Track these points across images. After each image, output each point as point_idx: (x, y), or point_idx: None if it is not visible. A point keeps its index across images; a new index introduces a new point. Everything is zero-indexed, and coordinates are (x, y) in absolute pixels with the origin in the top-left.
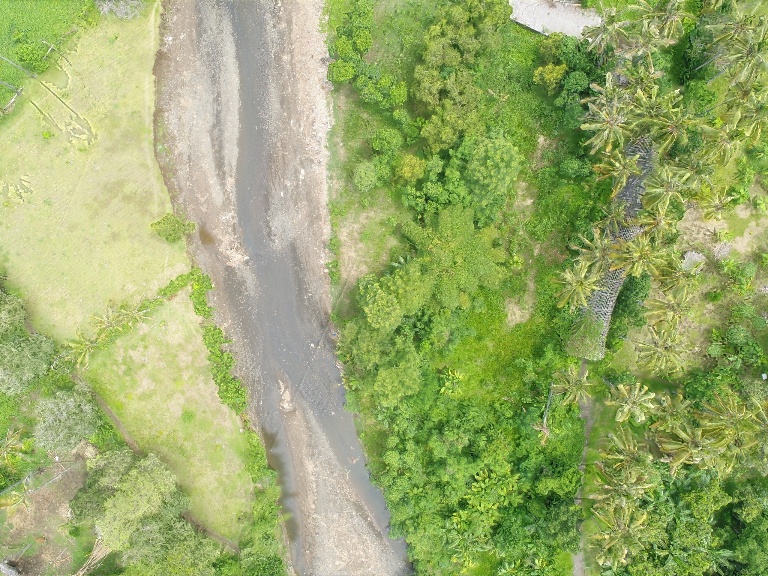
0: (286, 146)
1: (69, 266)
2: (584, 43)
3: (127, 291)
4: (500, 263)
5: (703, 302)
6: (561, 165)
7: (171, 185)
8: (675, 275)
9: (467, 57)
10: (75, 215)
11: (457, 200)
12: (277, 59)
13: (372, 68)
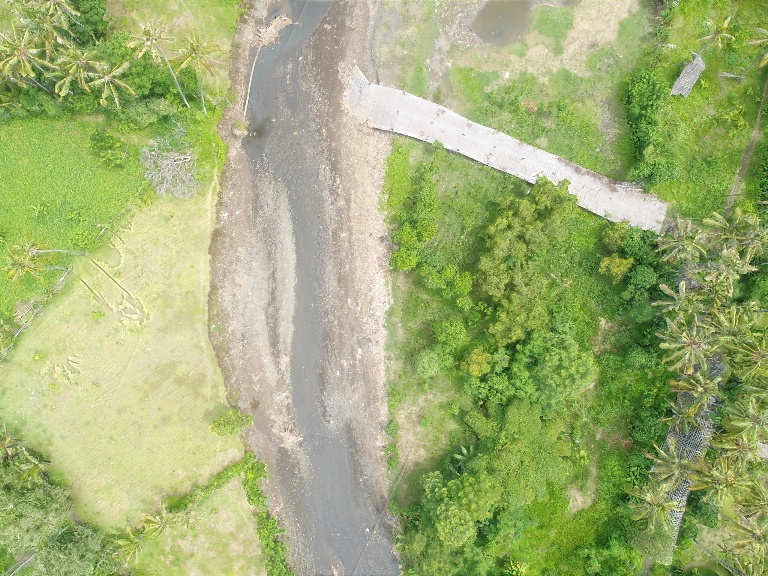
0: (343, 325)
1: (116, 450)
2: (650, 237)
3: (177, 477)
4: (566, 457)
5: (767, 491)
6: (627, 357)
7: (224, 365)
8: (759, 503)
9: (532, 248)
10: (124, 397)
11: (523, 395)
12: (335, 236)
13: (436, 257)
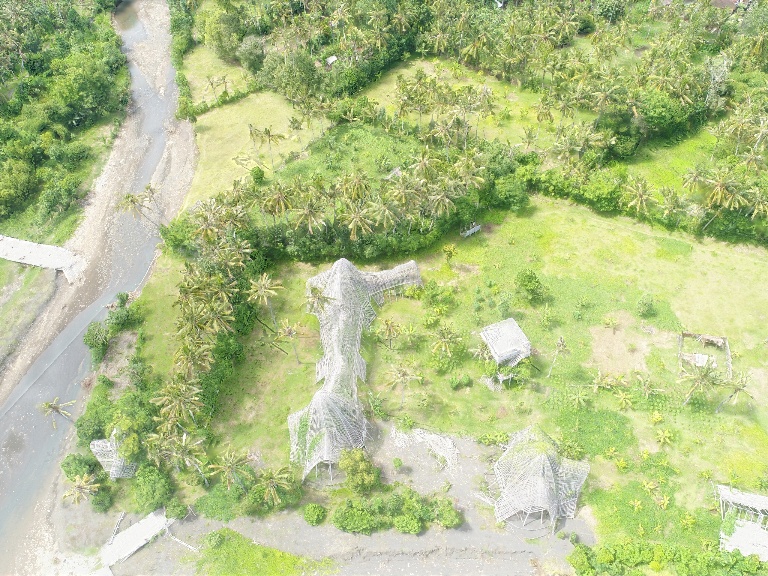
0: None
1: (260, 115)
2: None
3: None
4: None
5: None
6: None
7: None
8: None
9: None
10: None
11: None
12: None
13: None
